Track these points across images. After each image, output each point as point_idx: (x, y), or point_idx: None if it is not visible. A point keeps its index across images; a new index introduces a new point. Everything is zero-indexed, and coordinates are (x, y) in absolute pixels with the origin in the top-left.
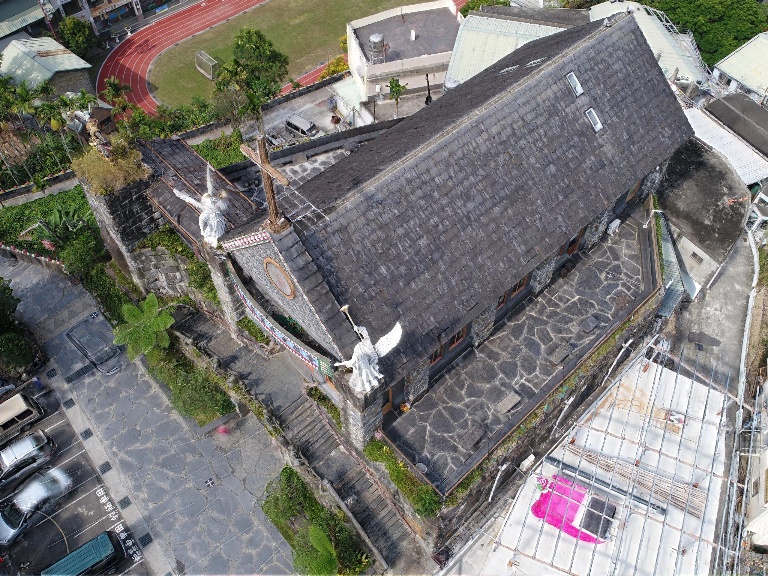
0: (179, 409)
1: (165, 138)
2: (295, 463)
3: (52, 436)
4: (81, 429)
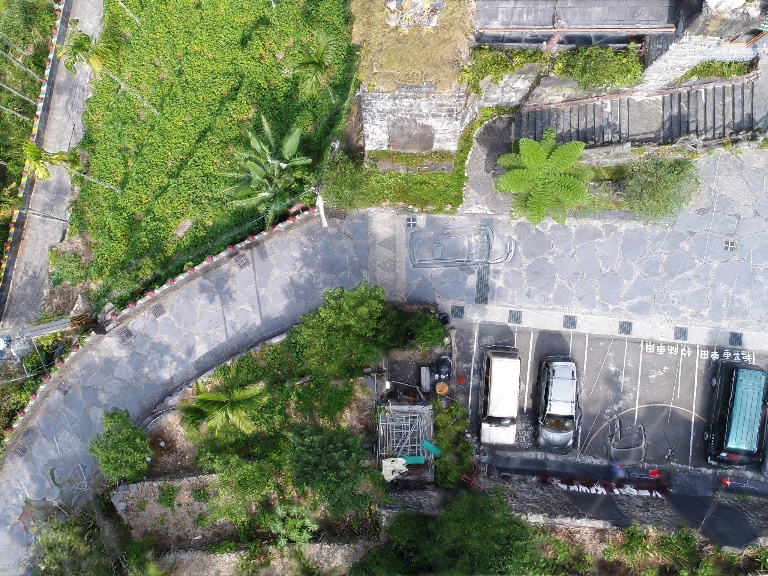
0: (662, 217)
1: None
2: None
3: None
4: (559, 324)
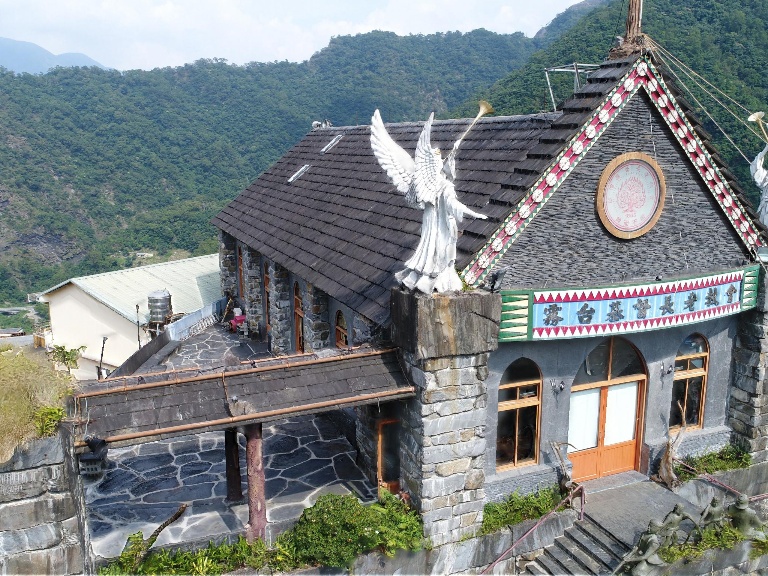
0: None
1: None
2: None
3: None
4: None
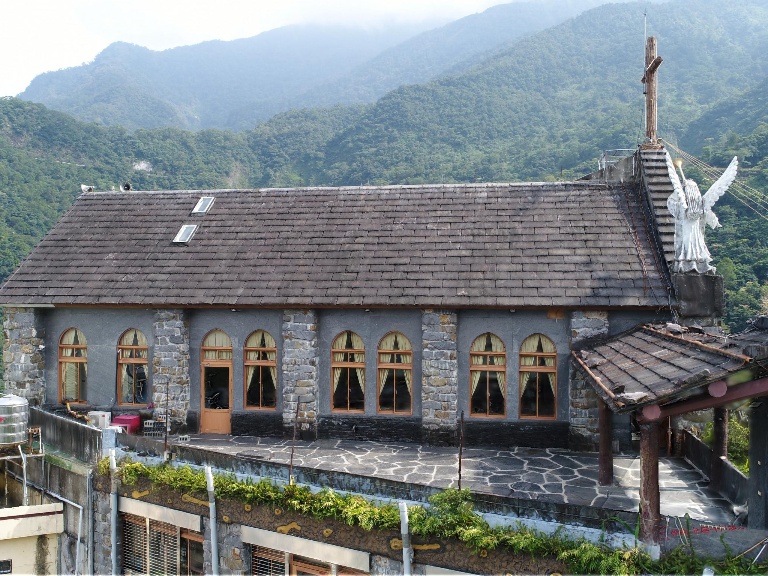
0: None
1: (669, 393)
2: None
3: None
4: None
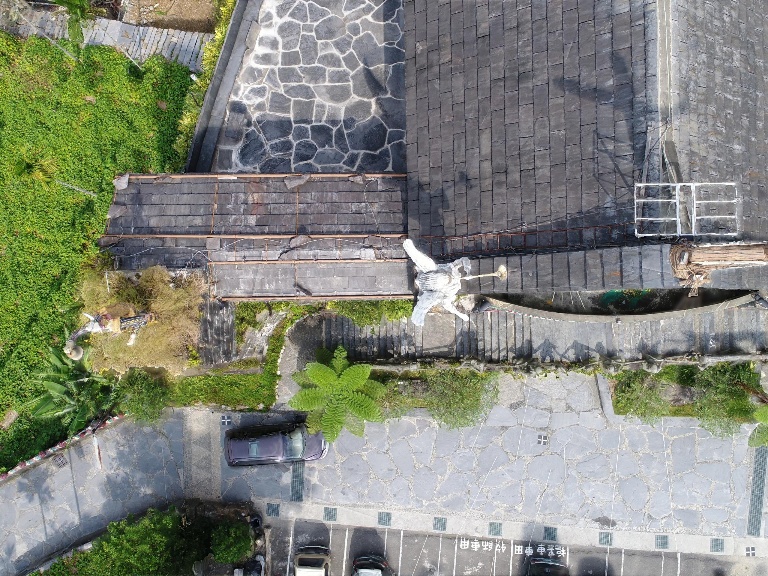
0: (463, 425)
1: None
2: (657, 372)
3: (361, 555)
4: (373, 521)
